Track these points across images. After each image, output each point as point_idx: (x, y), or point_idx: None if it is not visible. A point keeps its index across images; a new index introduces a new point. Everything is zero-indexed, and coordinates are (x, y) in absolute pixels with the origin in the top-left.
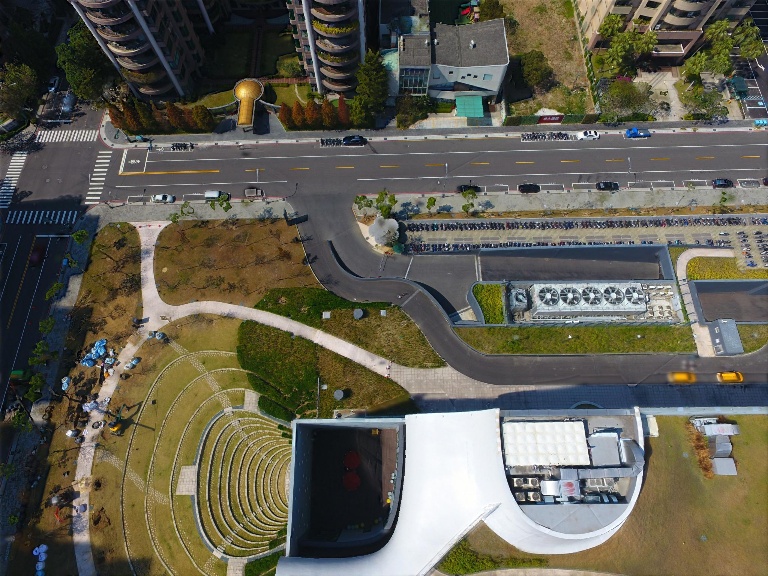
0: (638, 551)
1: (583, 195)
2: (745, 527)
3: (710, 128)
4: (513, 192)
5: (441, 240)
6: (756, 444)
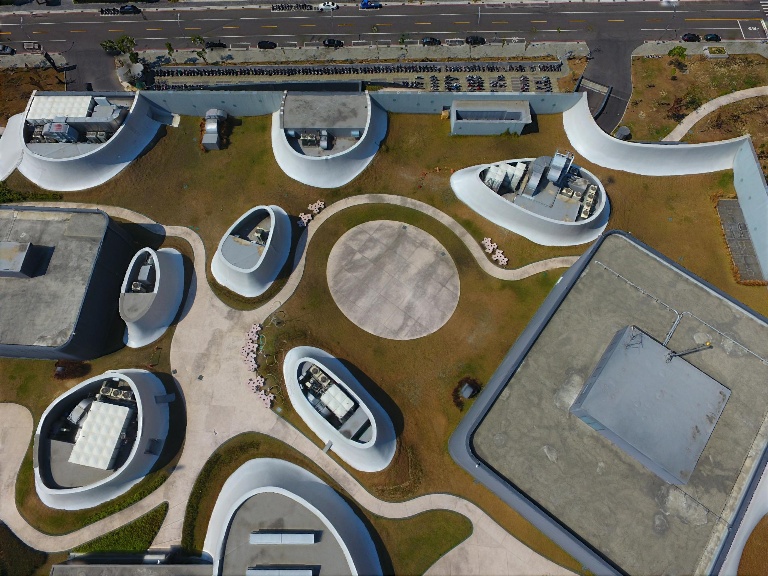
0: (131, 191)
1: (311, 50)
2: (218, 180)
3: (435, 2)
4: (253, 48)
5: (183, 83)
6: (250, 133)
